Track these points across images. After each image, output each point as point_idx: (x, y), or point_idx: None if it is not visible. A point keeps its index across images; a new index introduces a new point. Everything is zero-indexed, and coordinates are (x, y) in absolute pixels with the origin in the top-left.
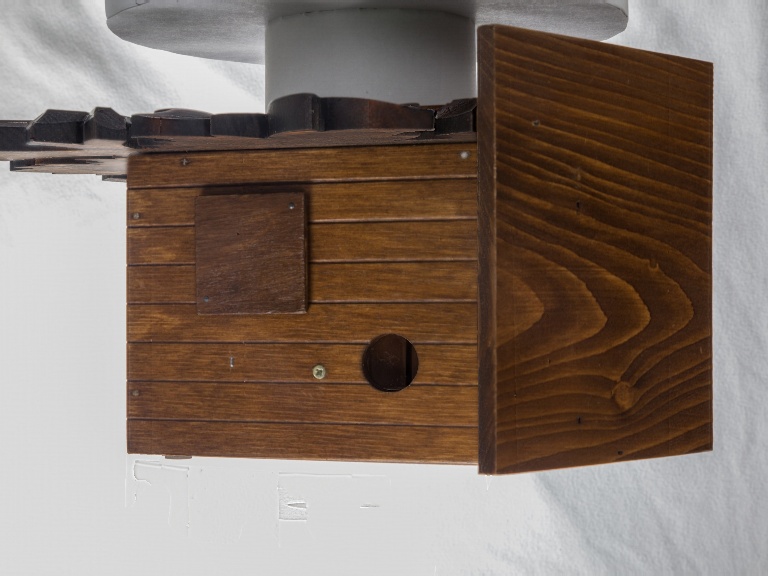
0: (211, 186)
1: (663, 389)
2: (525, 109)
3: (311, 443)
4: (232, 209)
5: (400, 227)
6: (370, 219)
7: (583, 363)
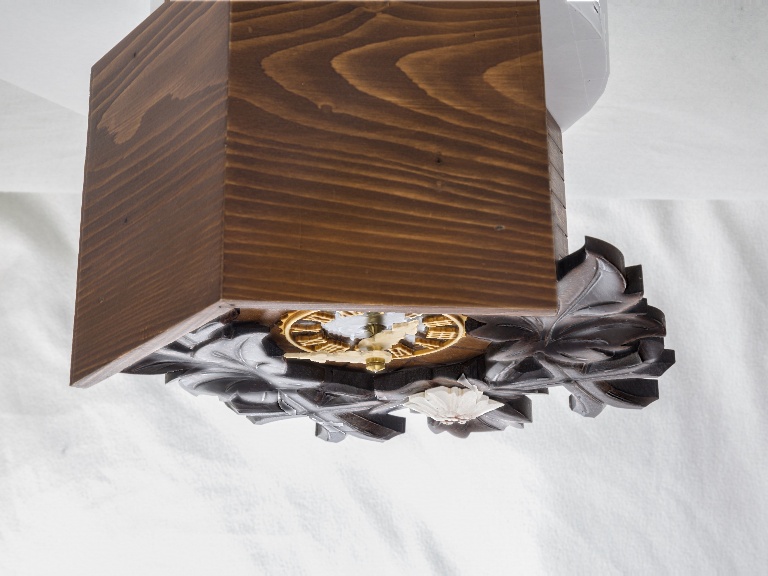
0: None
1: (312, 1)
2: (514, 239)
3: None
4: None
5: None
6: None
7: (429, 31)
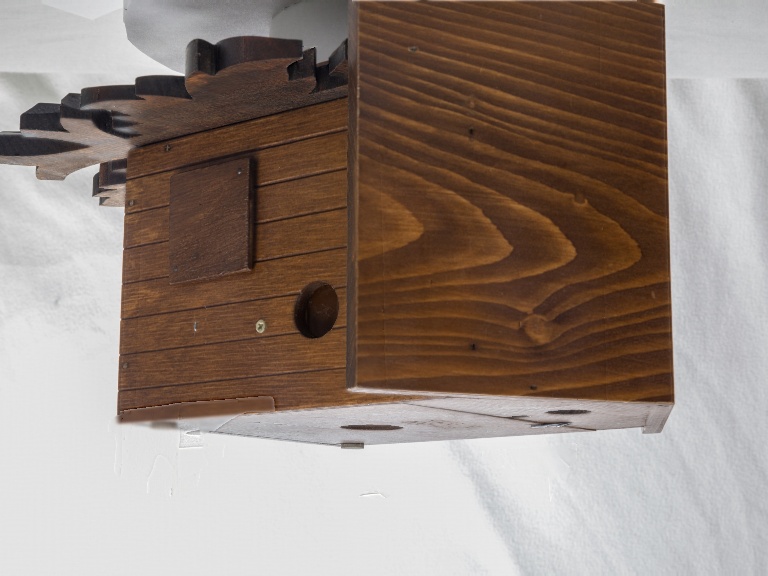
0: (186, 166)
1: (596, 329)
2: (399, 35)
3: (253, 396)
4: (196, 182)
5: (326, 178)
6: (303, 175)
7: (479, 289)
